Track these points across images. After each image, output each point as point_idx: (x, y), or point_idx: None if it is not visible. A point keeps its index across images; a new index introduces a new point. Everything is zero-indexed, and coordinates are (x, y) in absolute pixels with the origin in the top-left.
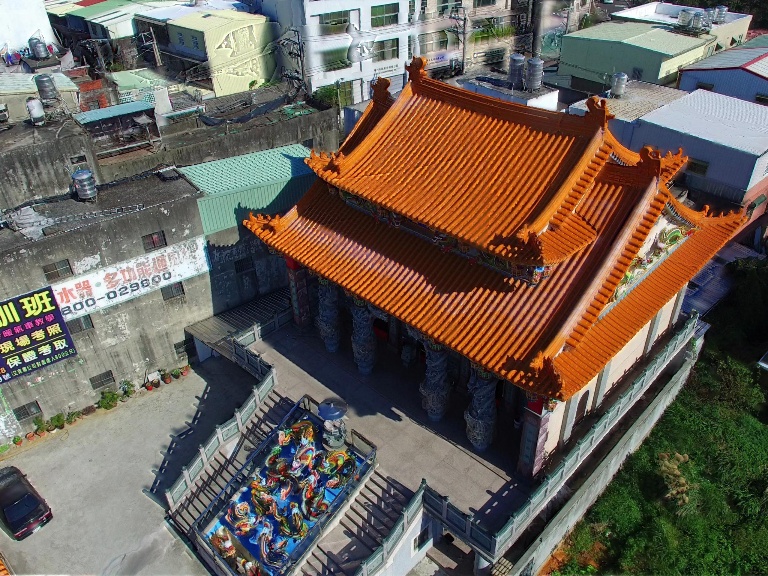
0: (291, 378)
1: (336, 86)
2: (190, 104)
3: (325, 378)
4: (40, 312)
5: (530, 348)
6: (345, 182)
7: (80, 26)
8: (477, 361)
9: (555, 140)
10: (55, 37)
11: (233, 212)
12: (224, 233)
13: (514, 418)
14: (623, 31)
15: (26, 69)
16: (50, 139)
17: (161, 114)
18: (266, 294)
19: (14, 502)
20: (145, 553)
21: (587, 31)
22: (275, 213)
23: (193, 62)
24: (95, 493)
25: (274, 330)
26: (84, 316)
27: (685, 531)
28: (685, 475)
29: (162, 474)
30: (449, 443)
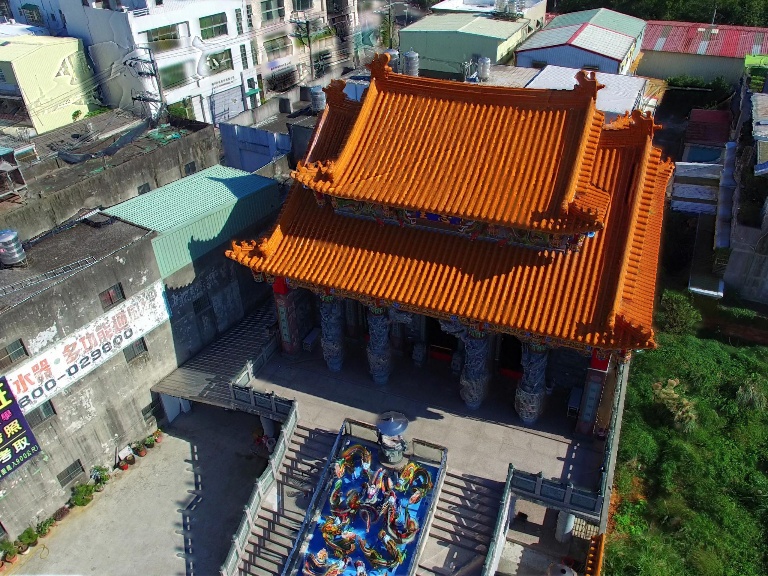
0: (310, 408)
1: (183, 105)
2: (17, 145)
3: (345, 398)
4: None
5: (593, 310)
6: (344, 189)
7: None
8: (550, 334)
9: (547, 116)
10: None
11: (187, 248)
12: (180, 273)
13: (546, 385)
14: (451, 22)
15: None
16: None
17: None
18: (225, 331)
19: None
20: None
21: (419, 25)
22: (226, 241)
23: (0, 98)
24: None
25: (263, 365)
26: (43, 403)
27: (697, 444)
28: None
29: (191, 555)
30: (499, 426)
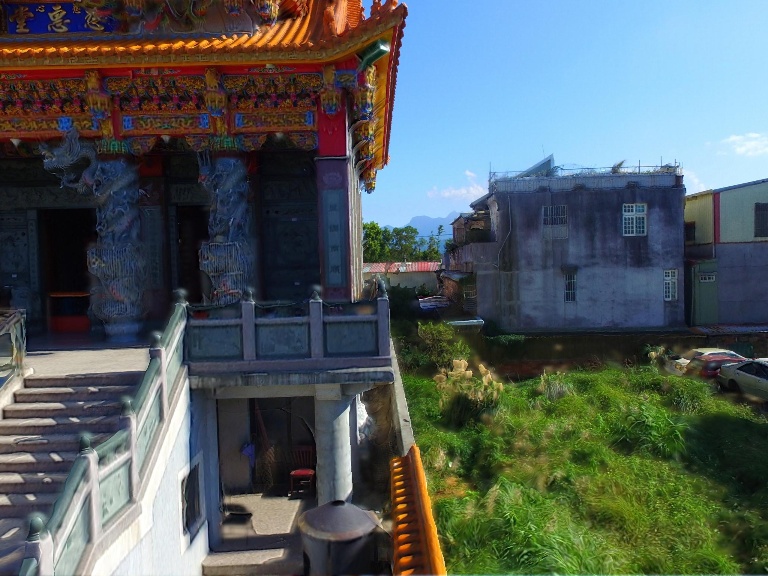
0: None
1: None
2: None
3: None
4: None
5: None
6: None
7: None
8: (231, 48)
9: None
10: None
11: None
12: None
13: None
14: None
15: None
16: None
17: None
18: None
19: None
20: None
21: None
22: None
23: None
24: None
25: None
26: None
27: None
28: None
29: None
30: None
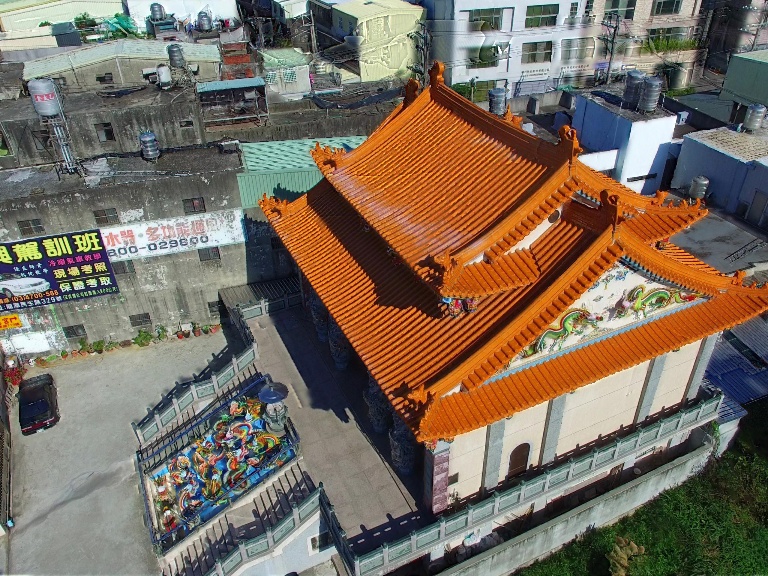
0: (274, 356)
1: (471, 84)
2: (329, 86)
3: (303, 364)
4: (89, 250)
5: (426, 379)
6: (336, 178)
7: (268, 4)
8: (376, 379)
9: (529, 167)
10: (238, 12)
11: (272, 191)
12: None
13: None
14: None
15: (190, 39)
16: (166, 102)
17: (300, 92)
18: None
19: (30, 403)
20: (108, 476)
21: (765, 52)
22: None
23: None
24: (97, 414)
25: (283, 309)
26: (128, 261)
27: None
28: (638, 569)
29: (153, 413)
30: (379, 457)
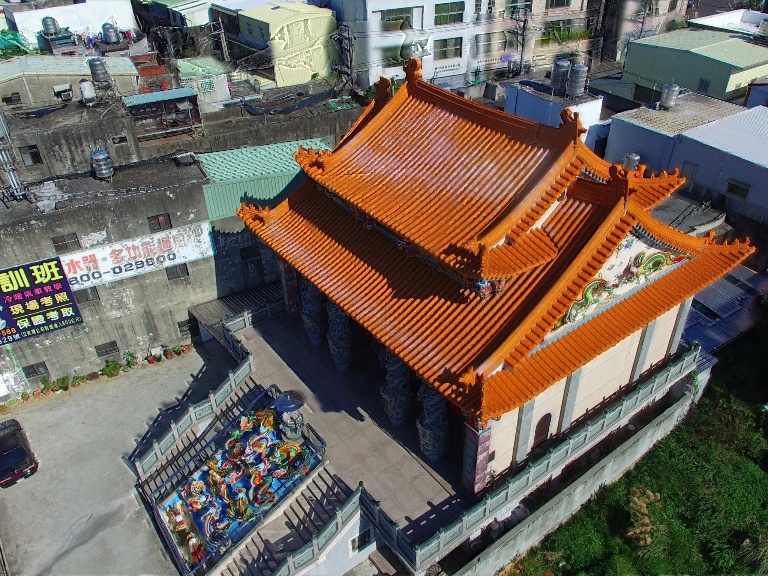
0: (270, 367)
1: None
2: (248, 93)
3: (302, 370)
4: (49, 280)
5: (468, 362)
6: (327, 179)
7: (164, 13)
8: None
9: (530, 151)
10: (136, 23)
11: (239, 200)
12: (230, 220)
13: None
14: (696, 39)
15: (97, 52)
16: (95, 119)
17: (219, 101)
18: (271, 283)
19: (4, 452)
20: (110, 516)
21: (657, 38)
22: None
23: None
24: (80, 454)
25: (266, 318)
26: (91, 287)
27: (644, 573)
28: (655, 515)
29: (143, 444)
30: (404, 449)
